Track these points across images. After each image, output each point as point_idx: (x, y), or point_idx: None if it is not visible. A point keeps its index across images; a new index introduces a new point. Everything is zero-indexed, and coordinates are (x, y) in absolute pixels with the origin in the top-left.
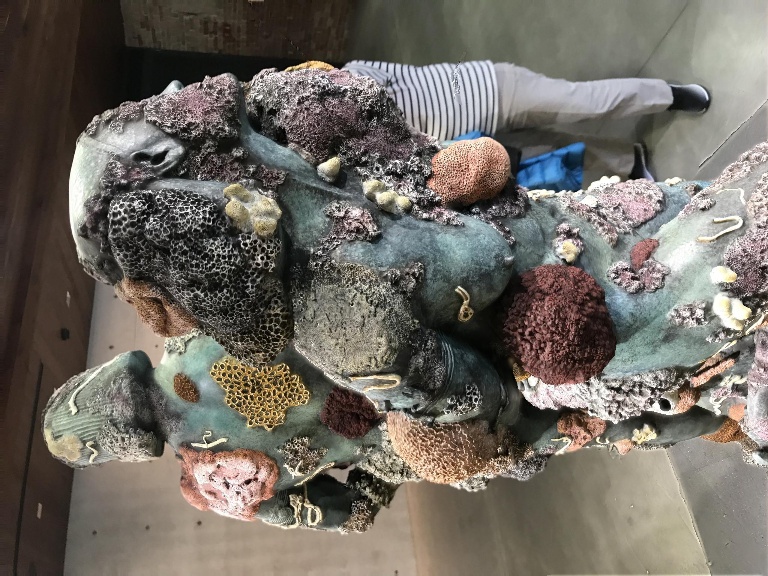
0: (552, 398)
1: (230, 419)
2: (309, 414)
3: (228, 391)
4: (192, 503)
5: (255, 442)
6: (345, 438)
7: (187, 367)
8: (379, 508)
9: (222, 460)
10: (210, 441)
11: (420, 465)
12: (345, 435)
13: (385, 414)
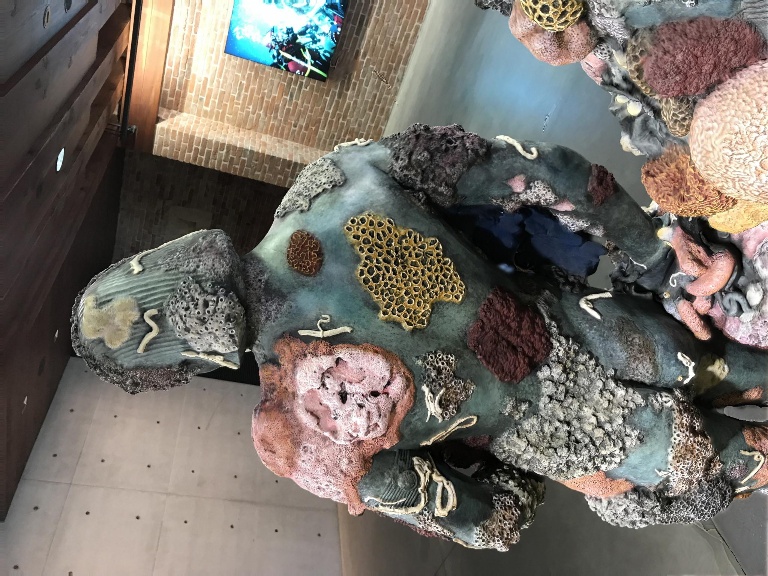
0: None
1: (356, 305)
2: (456, 326)
3: (365, 256)
4: (275, 440)
5: (389, 340)
6: (496, 378)
7: (311, 224)
8: (525, 519)
9: (345, 351)
10: (327, 328)
11: None
12: (497, 372)
13: (547, 354)
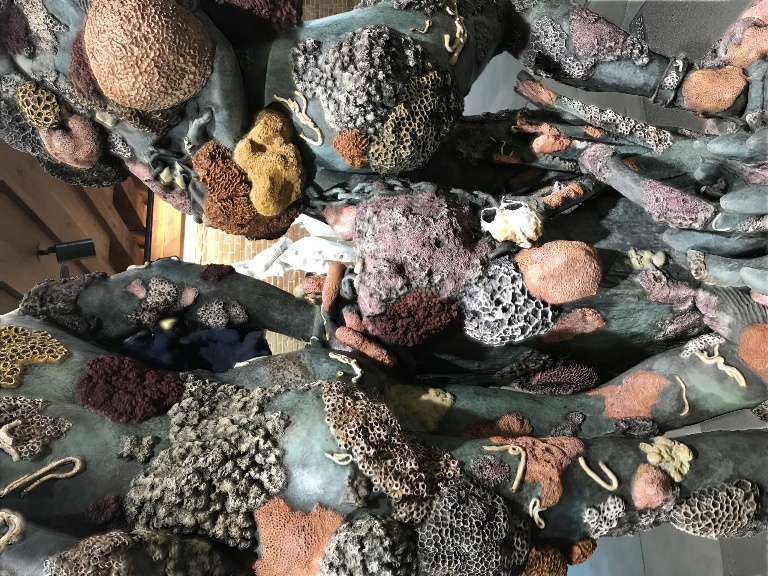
0: (381, 258)
1: None
2: (59, 387)
3: None
4: None
5: None
6: (107, 419)
7: None
8: (153, 568)
9: None
10: None
11: (97, 3)
12: (108, 414)
13: (180, 396)
